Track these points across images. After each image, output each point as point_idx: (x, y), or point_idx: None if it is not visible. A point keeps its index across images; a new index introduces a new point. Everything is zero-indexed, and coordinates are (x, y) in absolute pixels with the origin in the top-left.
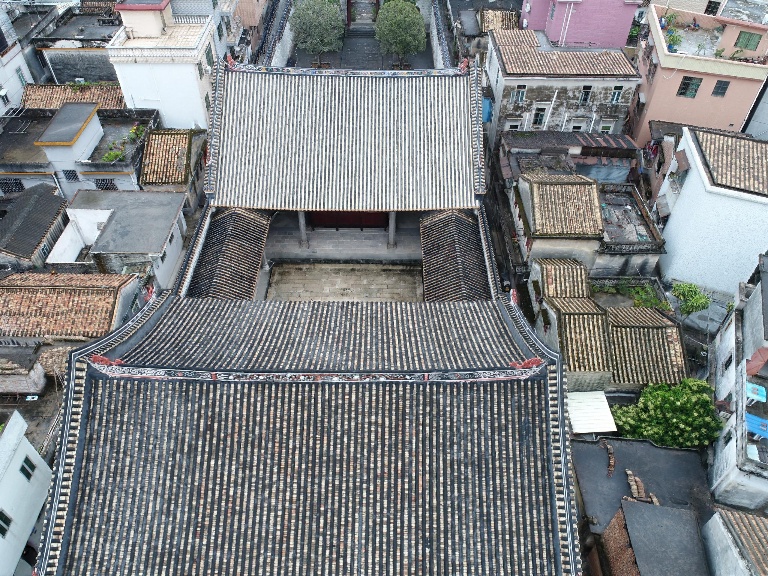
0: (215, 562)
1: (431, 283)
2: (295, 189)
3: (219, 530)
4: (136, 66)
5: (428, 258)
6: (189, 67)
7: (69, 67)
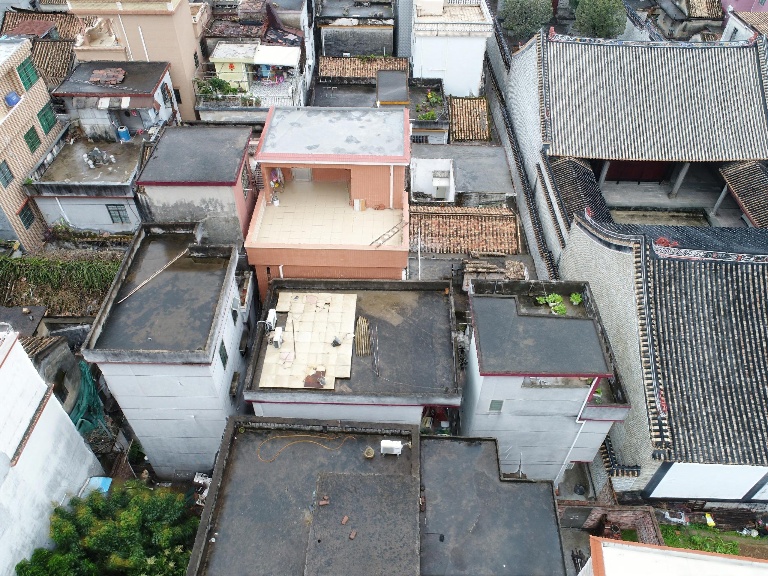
0: (766, 394)
1: (761, 218)
2: (615, 142)
3: (762, 372)
4: (435, 39)
5: (746, 199)
6: (481, 41)
7: (339, 43)
